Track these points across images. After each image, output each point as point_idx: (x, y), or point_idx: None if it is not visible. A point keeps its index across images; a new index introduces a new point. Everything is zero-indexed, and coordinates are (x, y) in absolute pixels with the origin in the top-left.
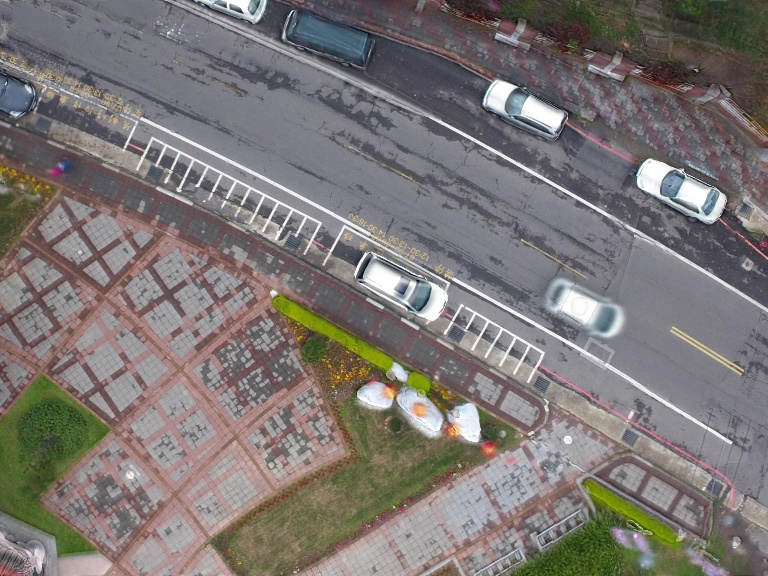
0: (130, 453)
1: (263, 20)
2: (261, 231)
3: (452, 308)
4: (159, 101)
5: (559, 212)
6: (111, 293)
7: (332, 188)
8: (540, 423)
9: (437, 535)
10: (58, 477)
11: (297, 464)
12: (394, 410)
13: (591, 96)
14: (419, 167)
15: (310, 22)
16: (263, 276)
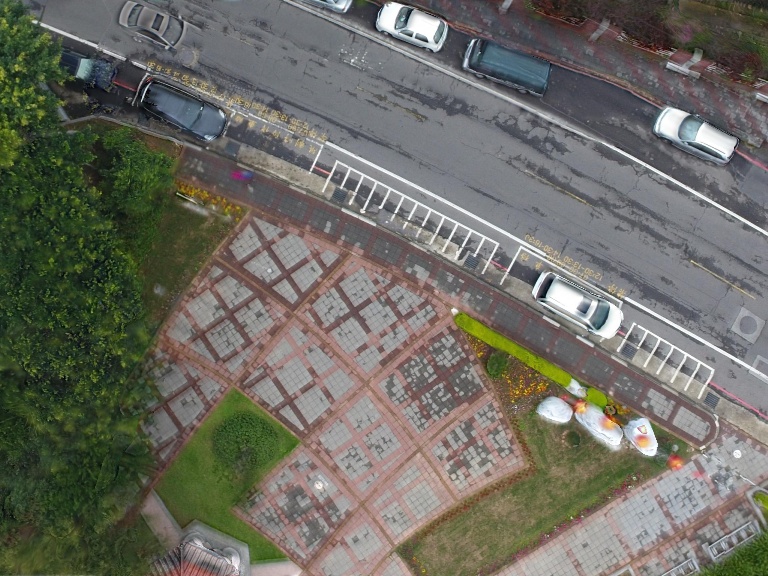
0: (319, 464)
1: (443, 49)
2: (441, 251)
3: (625, 326)
4: (343, 126)
5: (727, 234)
6: (299, 310)
7: (509, 210)
8: (711, 438)
9: (612, 545)
10: (250, 487)
11: (478, 476)
12: (571, 424)
13: (758, 123)
14: (592, 190)
15: (496, 51)
16: (444, 294)
